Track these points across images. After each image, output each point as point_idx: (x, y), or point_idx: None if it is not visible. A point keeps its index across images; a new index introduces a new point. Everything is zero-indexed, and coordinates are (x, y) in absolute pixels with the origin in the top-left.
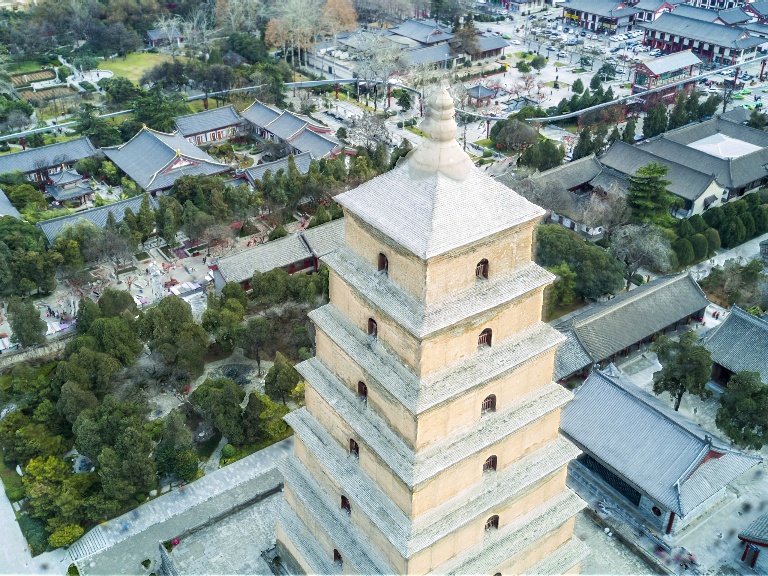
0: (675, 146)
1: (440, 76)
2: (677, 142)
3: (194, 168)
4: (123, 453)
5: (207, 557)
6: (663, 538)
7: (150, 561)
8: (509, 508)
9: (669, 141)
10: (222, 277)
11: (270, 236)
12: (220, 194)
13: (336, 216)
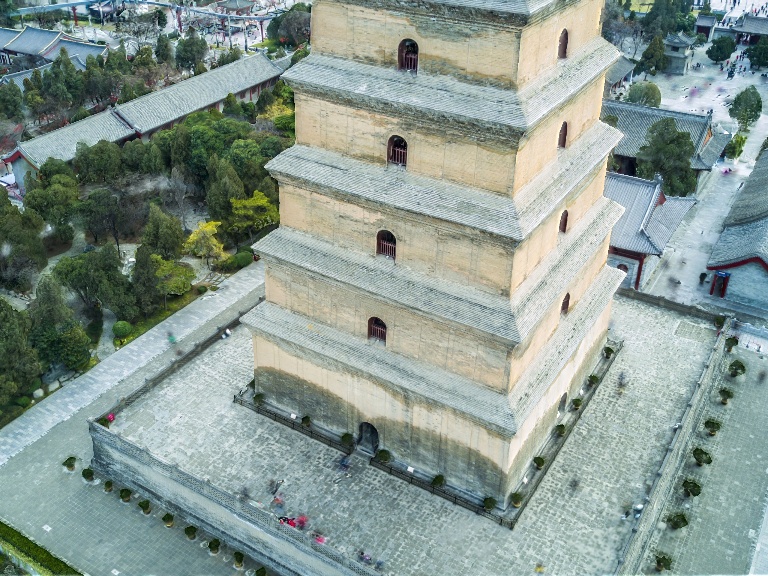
0: None
1: None
2: None
3: None
4: None
5: (162, 422)
6: None
7: (74, 458)
8: (573, 204)
9: None
10: (29, 165)
11: None
12: None
13: None
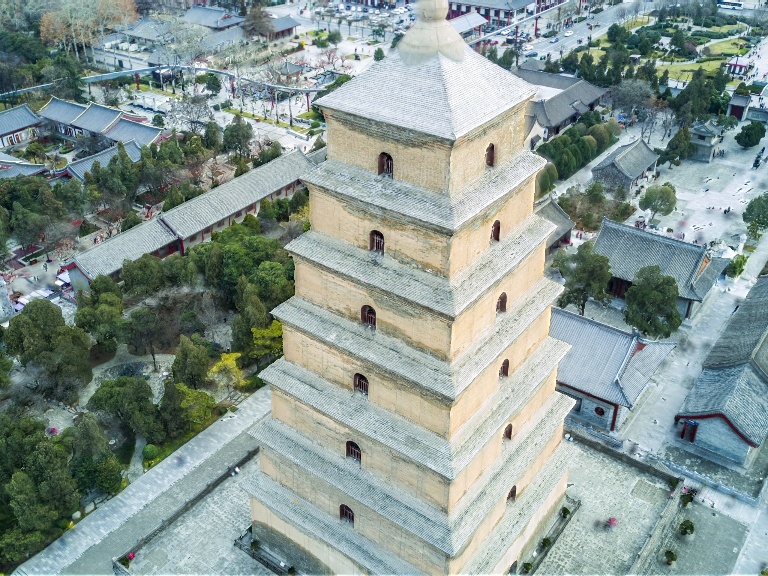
0: None
1: (255, 50)
2: None
3: (4, 172)
4: (37, 475)
5: (173, 563)
6: (610, 435)
7: None
8: (519, 415)
9: None
10: (83, 275)
11: (123, 226)
12: (49, 192)
13: (189, 197)
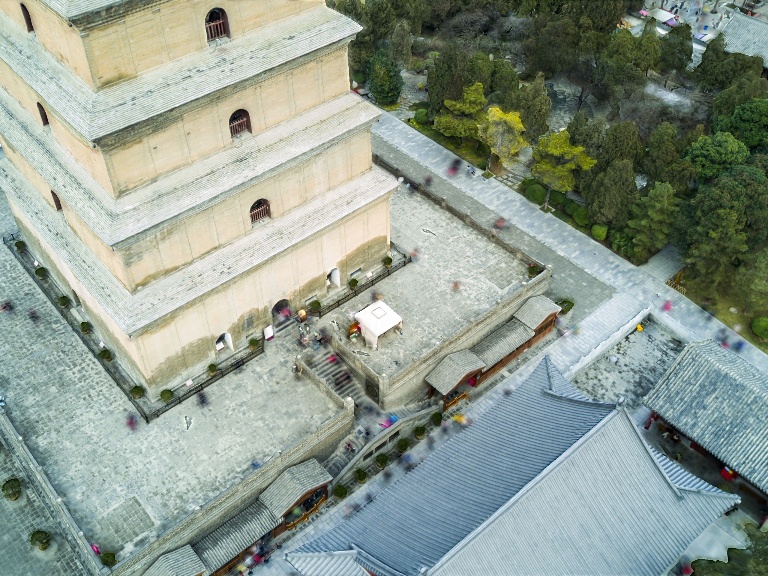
0: None
1: None
2: None
3: None
4: None
5: None
6: None
7: None
8: None
9: None
10: None
11: None
12: None
13: None
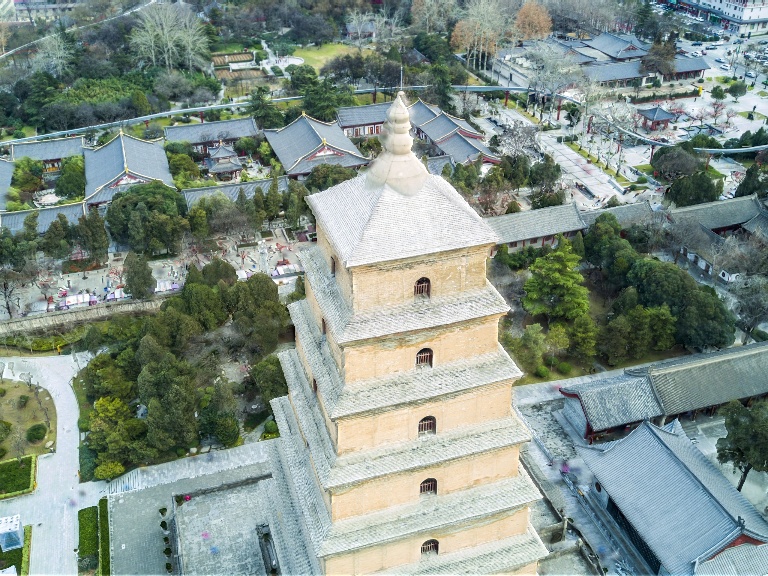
0: None
1: (603, 93)
2: None
3: (337, 158)
4: (168, 408)
5: (209, 518)
6: None
7: (167, 510)
8: (452, 536)
9: None
10: None
11: None
12: None
13: None
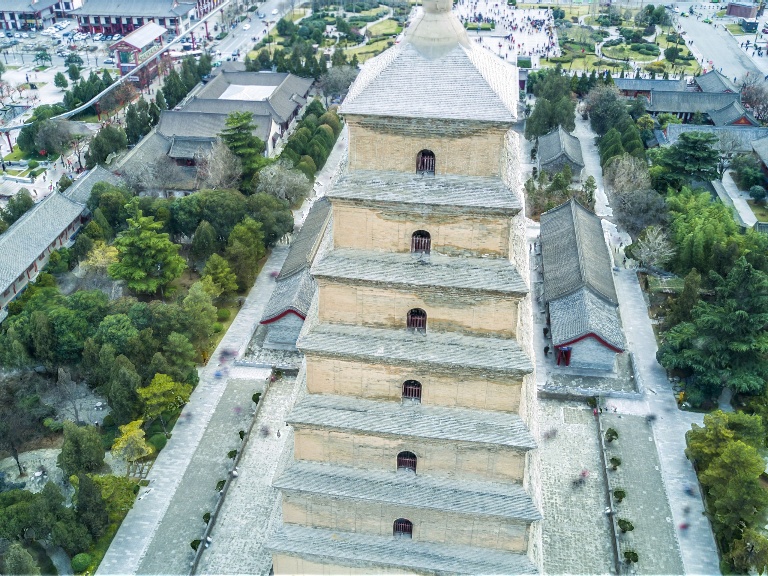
0: (212, 103)
1: None
2: (212, 99)
3: None
4: None
5: None
6: None
7: None
8: None
9: (204, 100)
10: None
11: None
12: None
13: None
